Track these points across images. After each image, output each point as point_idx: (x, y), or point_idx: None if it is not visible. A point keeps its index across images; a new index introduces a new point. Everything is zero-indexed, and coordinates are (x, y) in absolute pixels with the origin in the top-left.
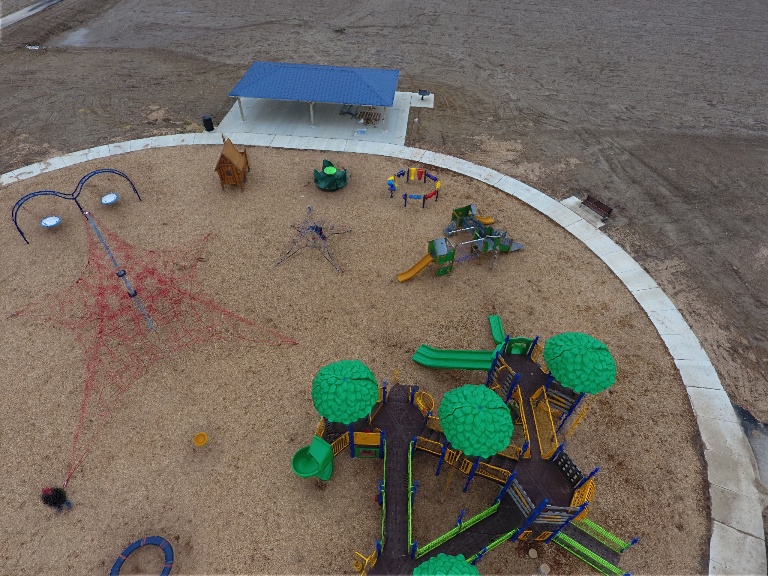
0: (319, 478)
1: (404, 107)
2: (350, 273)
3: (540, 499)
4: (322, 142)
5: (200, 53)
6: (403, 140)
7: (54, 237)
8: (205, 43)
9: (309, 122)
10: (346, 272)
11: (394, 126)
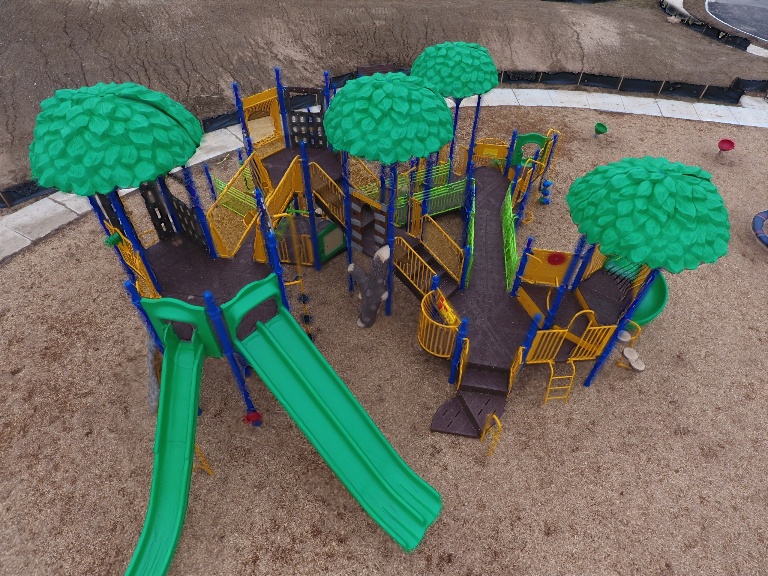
0: None
1: None
2: None
3: None
4: None
5: None
6: None
7: None
8: None
9: None
10: None
11: None
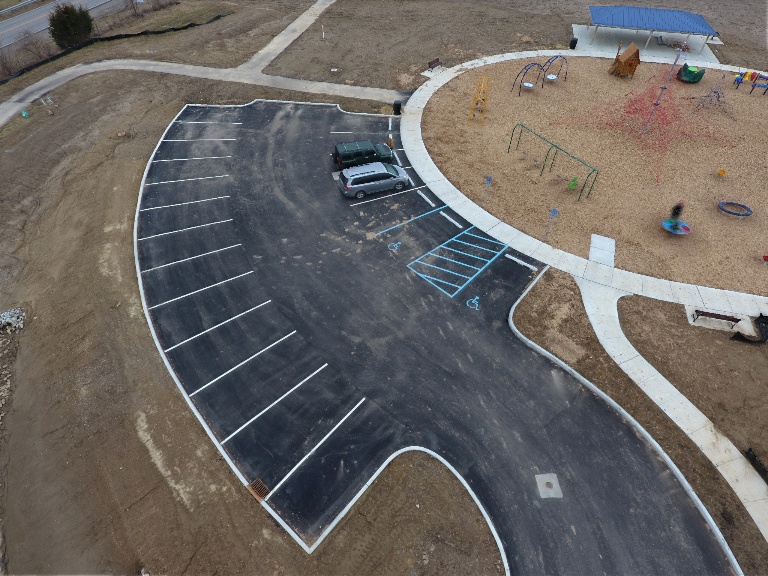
0: None
1: (702, 43)
2: (741, 121)
3: None
4: (659, 59)
5: (509, 7)
6: (718, 61)
7: (532, 94)
8: (505, 1)
9: (639, 48)
10: (738, 120)
11: (704, 53)
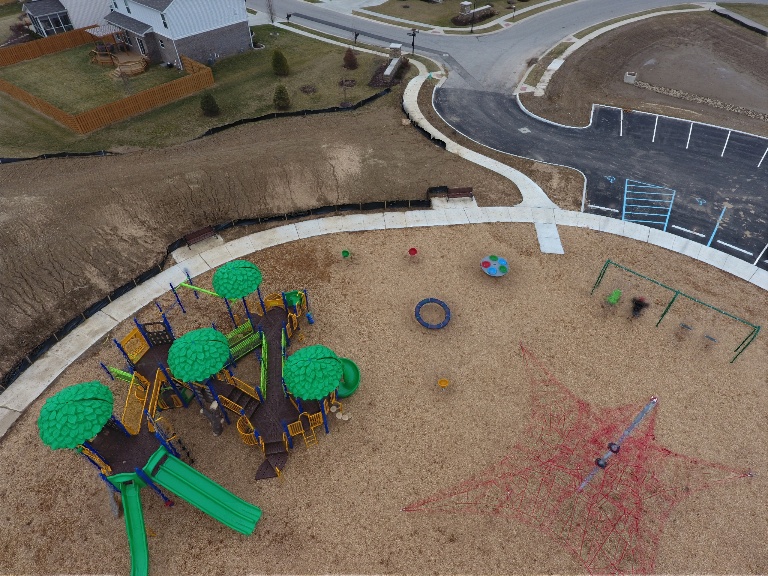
0: (340, 381)
1: None
2: None
3: (164, 356)
4: None
5: None
6: None
7: None
8: None
9: None
10: None
11: None
